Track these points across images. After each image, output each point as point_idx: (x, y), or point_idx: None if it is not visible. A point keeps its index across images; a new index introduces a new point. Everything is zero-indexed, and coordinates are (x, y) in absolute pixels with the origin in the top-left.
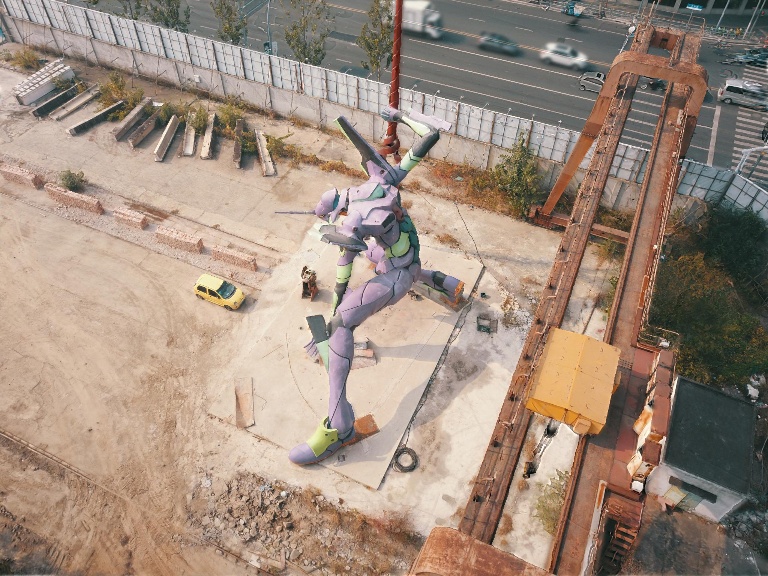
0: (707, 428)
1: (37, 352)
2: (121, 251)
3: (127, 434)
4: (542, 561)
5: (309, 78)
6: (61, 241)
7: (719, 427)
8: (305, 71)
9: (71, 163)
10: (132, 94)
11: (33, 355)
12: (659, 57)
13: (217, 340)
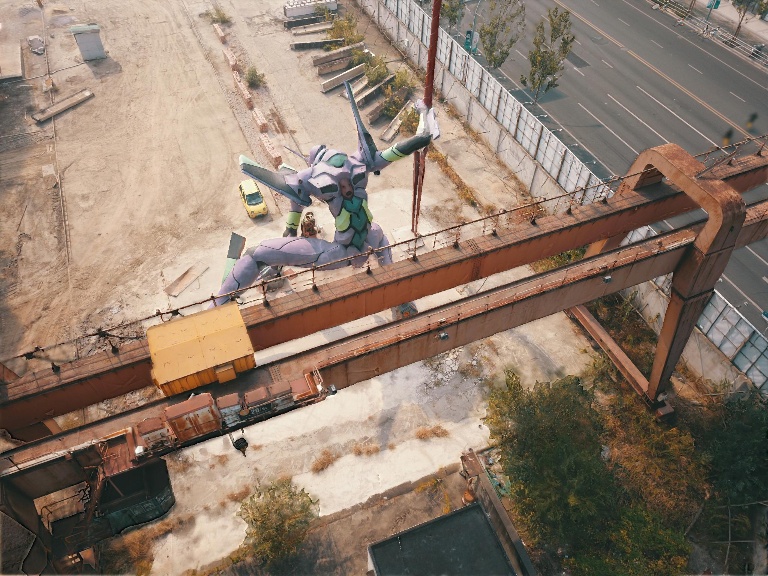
0: (447, 562)
1: (126, 172)
2: (233, 139)
3: (113, 251)
4: (232, 542)
5: (472, 73)
6: (210, 114)
7: (460, 571)
8: (471, 65)
9: (270, 67)
10: (352, 35)
11: (122, 173)
12: (699, 164)
13: (220, 230)
